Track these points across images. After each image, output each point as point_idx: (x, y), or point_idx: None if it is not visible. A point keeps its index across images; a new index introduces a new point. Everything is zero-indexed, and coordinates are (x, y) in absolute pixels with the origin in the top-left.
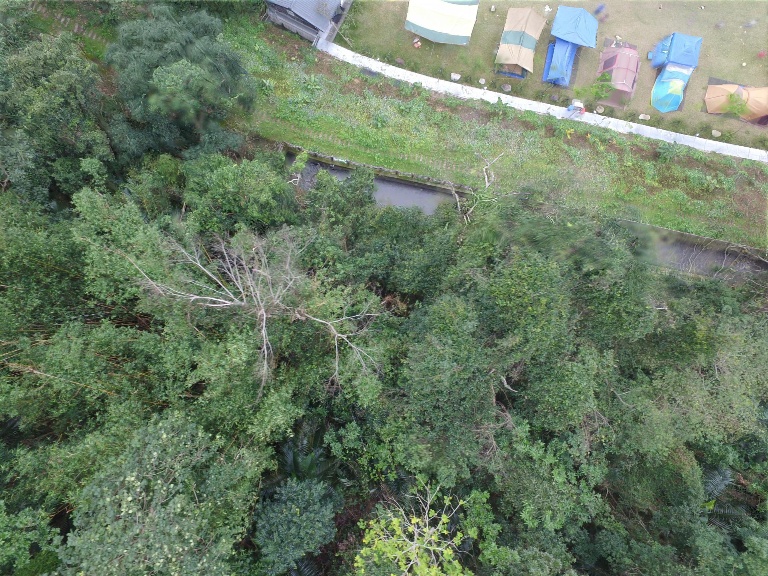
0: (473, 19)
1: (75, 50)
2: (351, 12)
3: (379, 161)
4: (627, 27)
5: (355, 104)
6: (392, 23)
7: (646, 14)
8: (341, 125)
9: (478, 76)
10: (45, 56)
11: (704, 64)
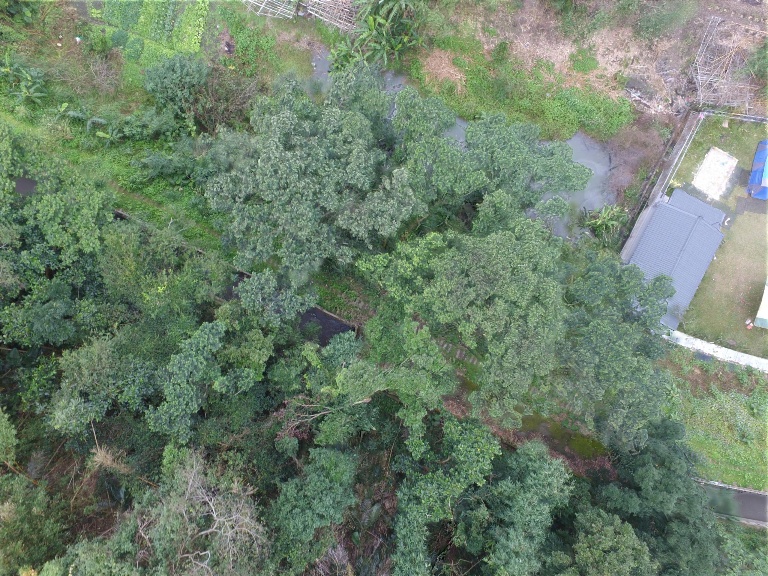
0: None
1: (638, 543)
2: None
3: (748, 479)
4: None
5: (710, 408)
6: (725, 304)
7: None
8: (712, 445)
9: None
10: (629, 567)
11: None
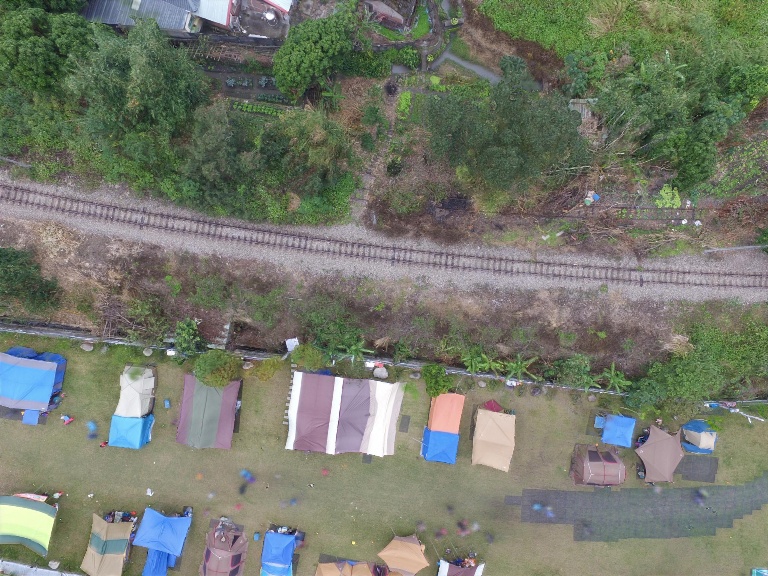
0: (48, 535)
1: None
2: None
3: None
4: (233, 507)
5: None
6: None
7: (252, 494)
8: None
9: (79, 561)
10: None
11: (314, 541)
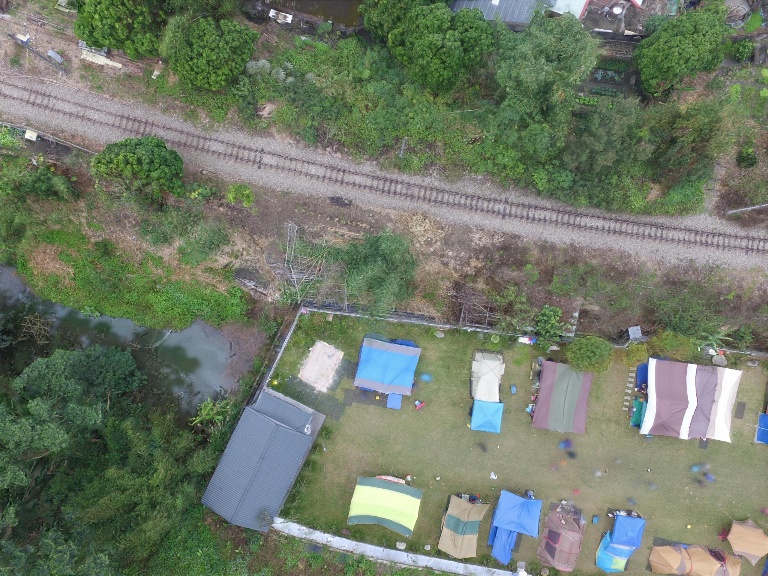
0: (415, 515)
1: None
2: (296, 486)
3: None
4: (572, 491)
5: None
6: (337, 494)
7: (592, 478)
8: None
9: (423, 542)
10: None
11: (649, 525)
